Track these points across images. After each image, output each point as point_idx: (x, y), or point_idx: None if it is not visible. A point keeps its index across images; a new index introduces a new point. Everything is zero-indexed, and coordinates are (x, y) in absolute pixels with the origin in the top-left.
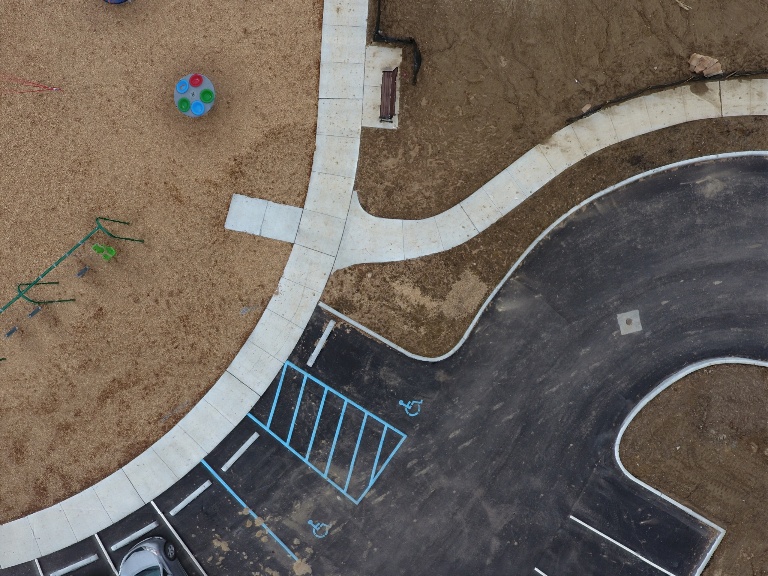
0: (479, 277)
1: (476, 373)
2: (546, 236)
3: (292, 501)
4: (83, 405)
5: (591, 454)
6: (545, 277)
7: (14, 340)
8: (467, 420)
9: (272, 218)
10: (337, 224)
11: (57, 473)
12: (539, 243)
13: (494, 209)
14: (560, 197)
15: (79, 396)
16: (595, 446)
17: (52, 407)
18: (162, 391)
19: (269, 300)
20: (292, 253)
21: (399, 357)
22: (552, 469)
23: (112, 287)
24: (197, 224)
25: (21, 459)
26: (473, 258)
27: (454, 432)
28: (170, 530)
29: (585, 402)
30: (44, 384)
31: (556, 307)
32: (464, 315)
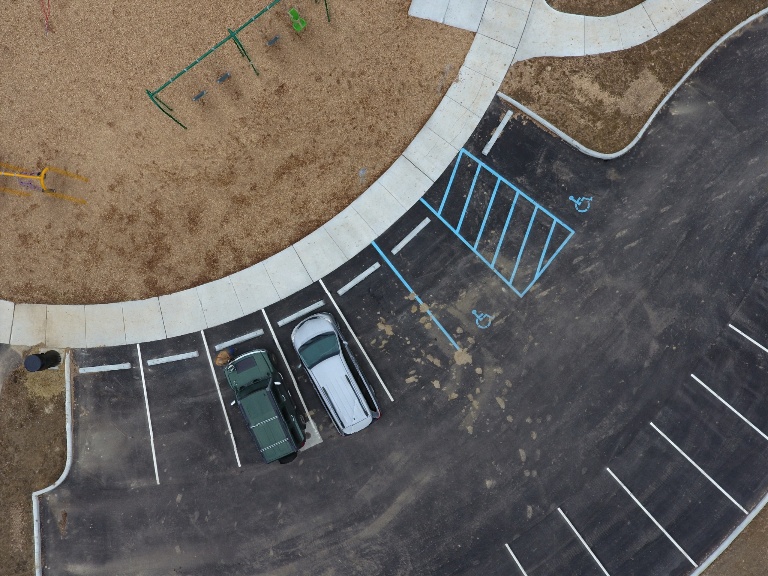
0: (656, 77)
1: (646, 174)
2: (722, 44)
3: (458, 289)
4: (259, 179)
5: (753, 264)
6: (719, 84)
7: (195, 111)
8: (634, 220)
9: (456, 7)
10: (520, 16)
11: (229, 246)
12: (715, 50)
13: (675, 11)
14: (740, 4)
15: (256, 170)
16: (758, 256)
17: (228, 180)
18: (337, 171)
19: (448, 87)
20: (474, 42)
21: (572, 152)
22: (714, 276)
23: (295, 65)
24: (382, 8)
25: (194, 230)
26: (651, 58)
27: (621, 232)
28: (336, 310)
29: (750, 212)
30: (222, 156)
31: (728, 115)
32: (639, 114)
